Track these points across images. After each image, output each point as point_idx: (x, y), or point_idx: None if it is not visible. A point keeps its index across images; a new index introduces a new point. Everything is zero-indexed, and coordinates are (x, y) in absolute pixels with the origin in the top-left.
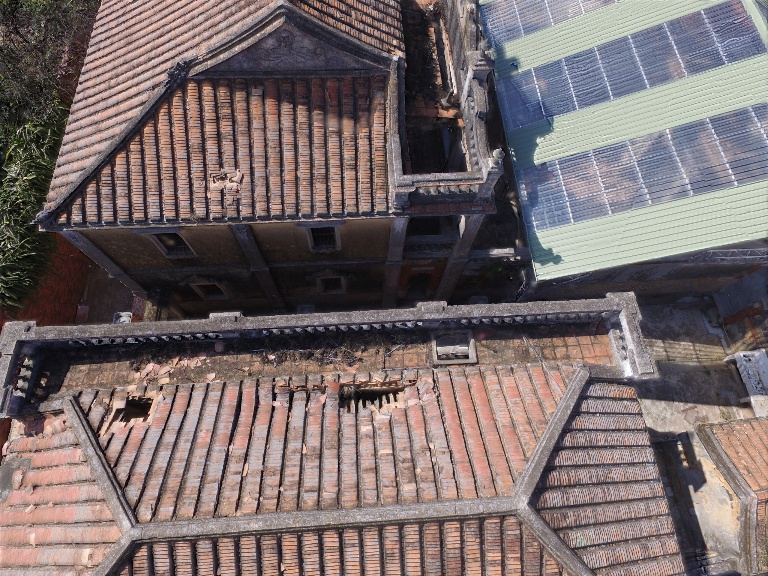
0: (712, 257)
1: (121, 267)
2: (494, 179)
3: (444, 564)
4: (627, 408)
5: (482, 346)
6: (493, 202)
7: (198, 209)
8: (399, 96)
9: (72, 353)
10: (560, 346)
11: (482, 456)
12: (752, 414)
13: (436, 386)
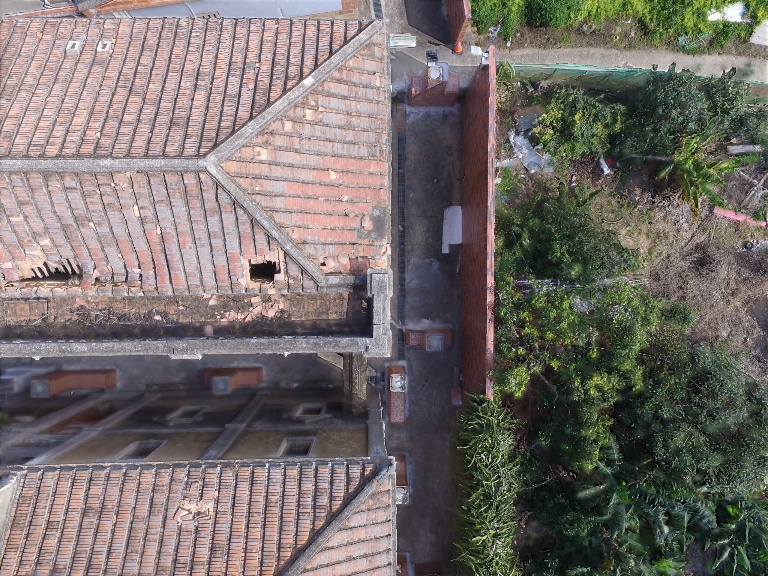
0: None
1: None
2: None
3: None
4: None
5: None
6: None
7: (229, 478)
8: None
9: (346, 330)
10: None
11: None
12: None
13: None
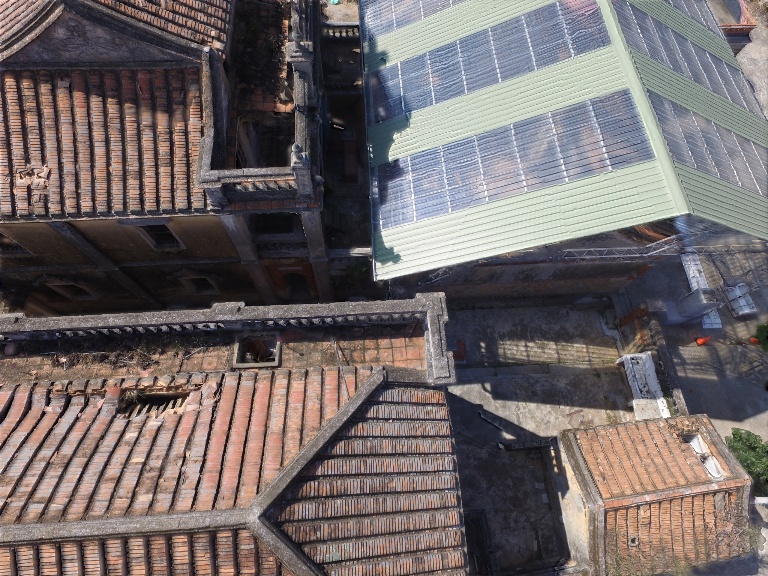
0: (566, 256)
1: None
2: (304, 175)
3: None
4: (430, 414)
5: (288, 349)
6: (320, 199)
7: (3, 206)
8: (215, 89)
9: None
10: (371, 349)
11: (235, 465)
12: (634, 418)
13: (220, 391)
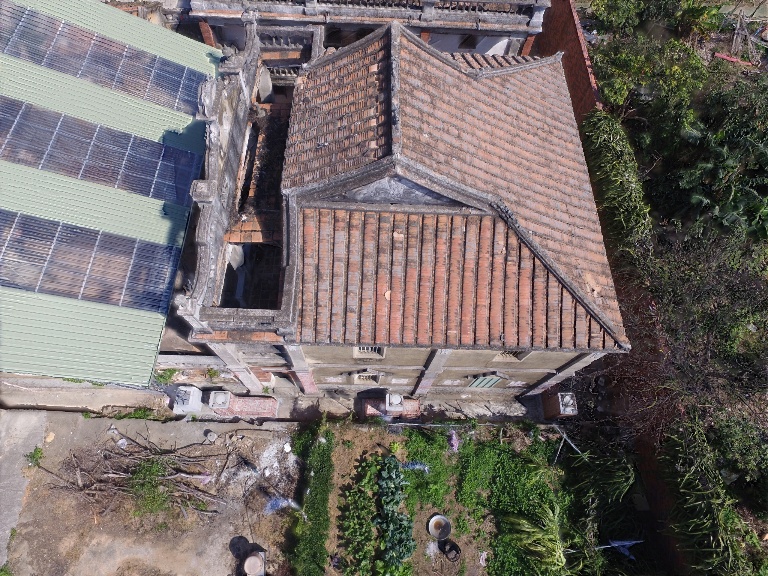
0: None
1: None
2: None
3: None
4: None
5: None
6: None
7: None
8: None
9: None
10: None
11: None
12: None
13: None
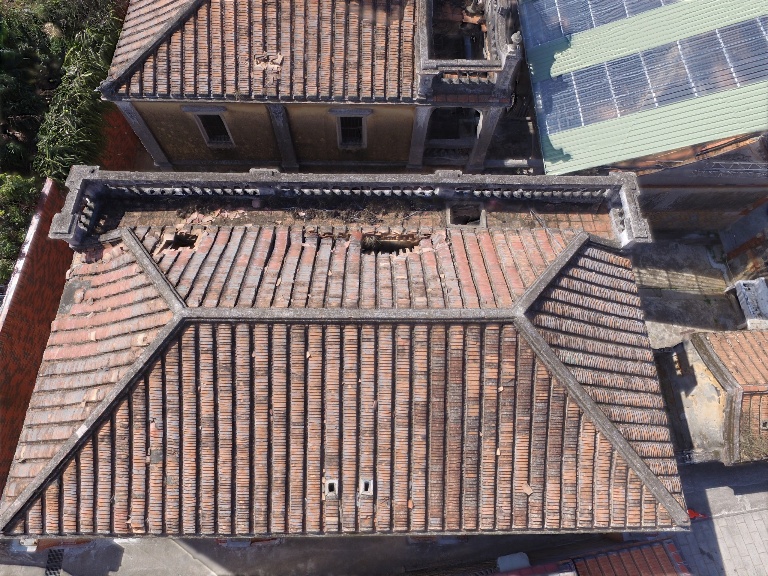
0: (714, 168)
1: (166, 154)
2: (511, 66)
3: (448, 364)
4: (621, 274)
5: (492, 216)
6: (509, 96)
7: (242, 86)
8: None
9: (127, 201)
10: (563, 221)
11: (486, 284)
12: None
13: (448, 239)
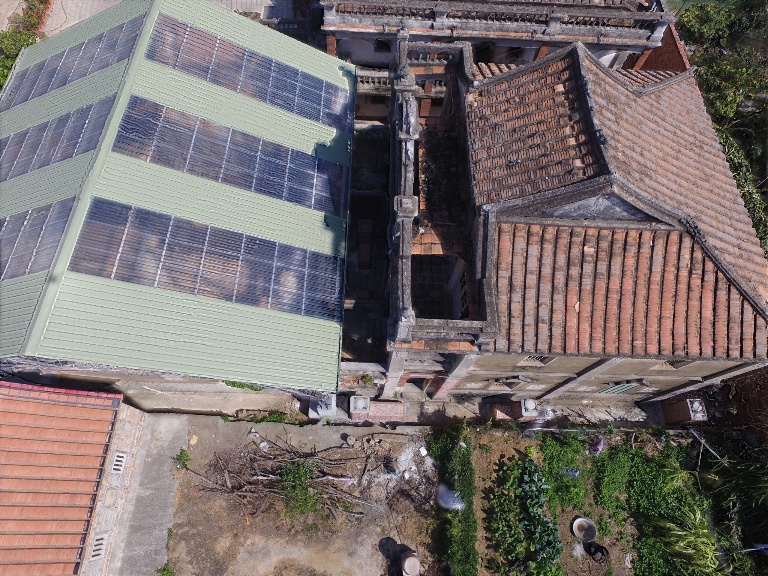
0: None
1: None
2: None
3: None
4: None
5: None
6: (391, 66)
7: None
8: None
9: None
10: None
11: None
12: None
13: None
